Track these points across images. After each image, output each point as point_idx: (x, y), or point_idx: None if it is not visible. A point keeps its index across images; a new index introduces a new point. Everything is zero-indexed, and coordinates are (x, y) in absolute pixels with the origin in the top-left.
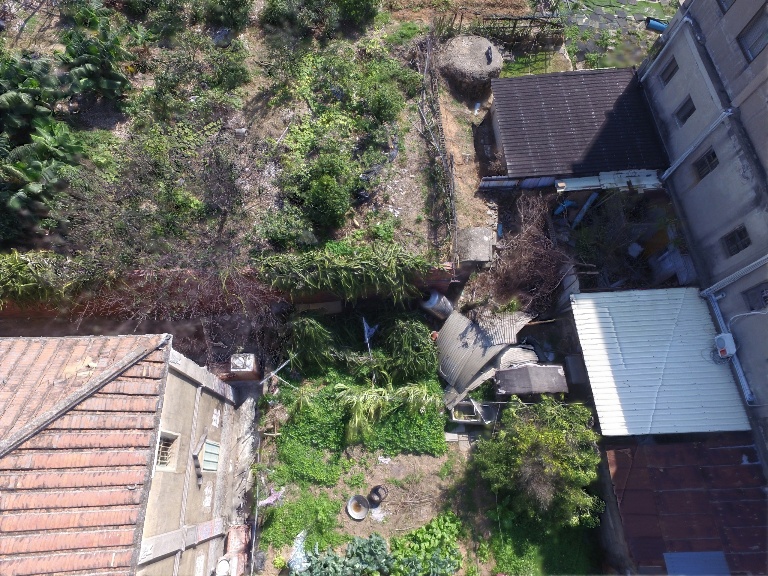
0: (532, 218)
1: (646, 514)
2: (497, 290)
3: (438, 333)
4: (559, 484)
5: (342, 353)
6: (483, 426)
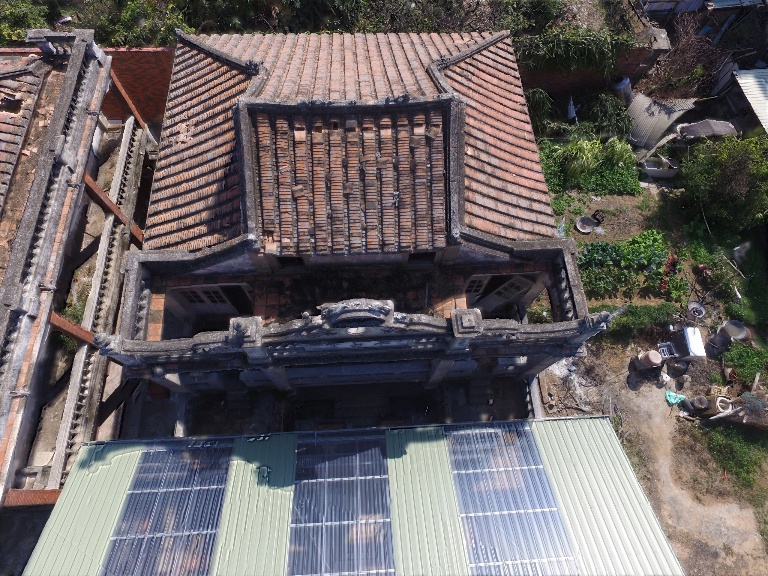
0: (689, 30)
1: None
2: (660, 90)
3: (627, 110)
4: (750, 183)
5: None
6: (665, 179)
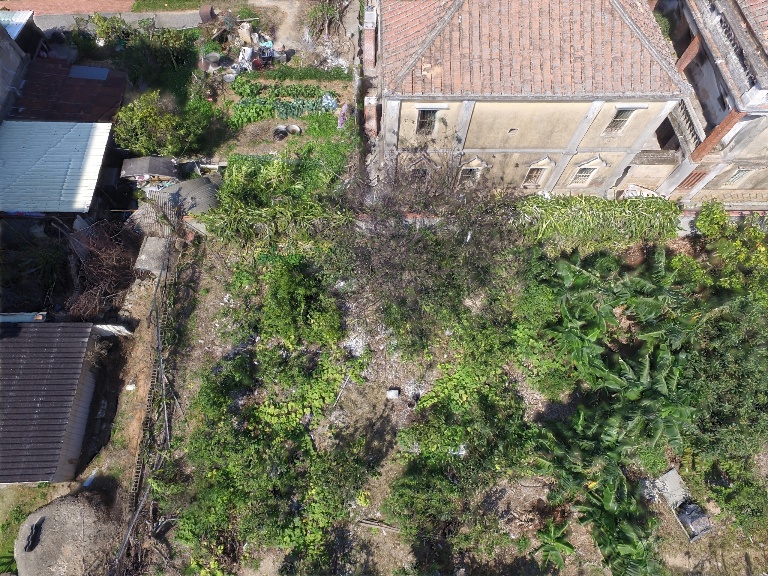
0: None
1: (106, 96)
2: None
3: None
4: None
5: None
6: None
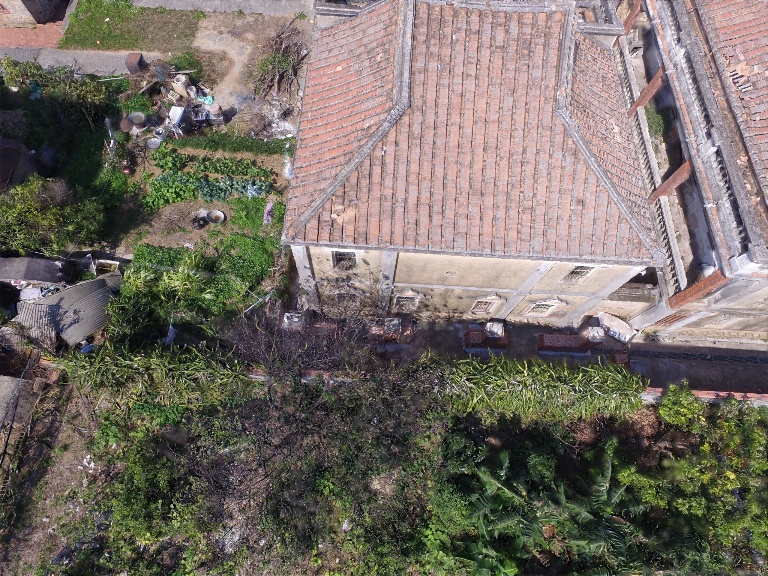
0: None
1: None
2: None
3: None
4: None
5: (199, 320)
6: None
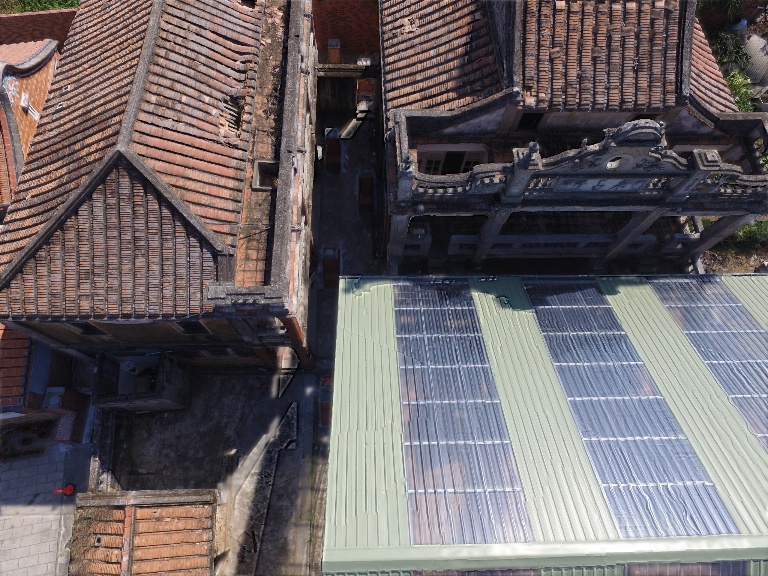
0: None
1: None
2: (767, 36)
3: None
4: None
5: None
6: None
